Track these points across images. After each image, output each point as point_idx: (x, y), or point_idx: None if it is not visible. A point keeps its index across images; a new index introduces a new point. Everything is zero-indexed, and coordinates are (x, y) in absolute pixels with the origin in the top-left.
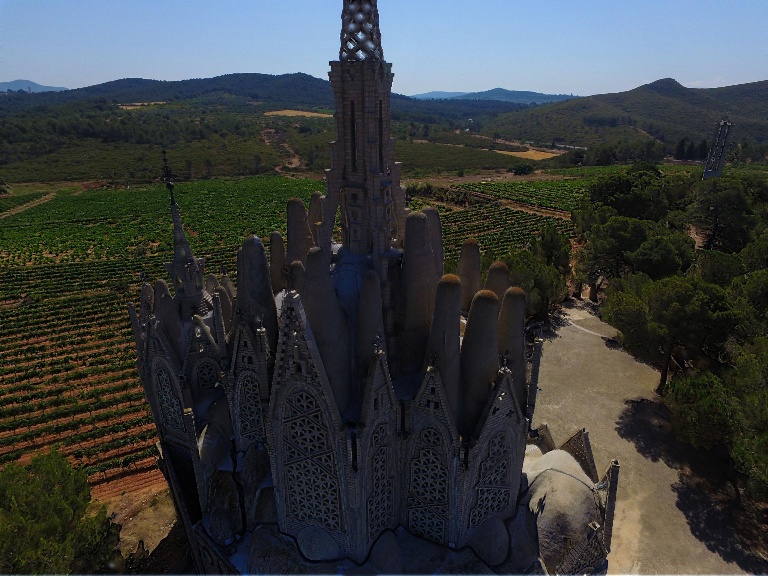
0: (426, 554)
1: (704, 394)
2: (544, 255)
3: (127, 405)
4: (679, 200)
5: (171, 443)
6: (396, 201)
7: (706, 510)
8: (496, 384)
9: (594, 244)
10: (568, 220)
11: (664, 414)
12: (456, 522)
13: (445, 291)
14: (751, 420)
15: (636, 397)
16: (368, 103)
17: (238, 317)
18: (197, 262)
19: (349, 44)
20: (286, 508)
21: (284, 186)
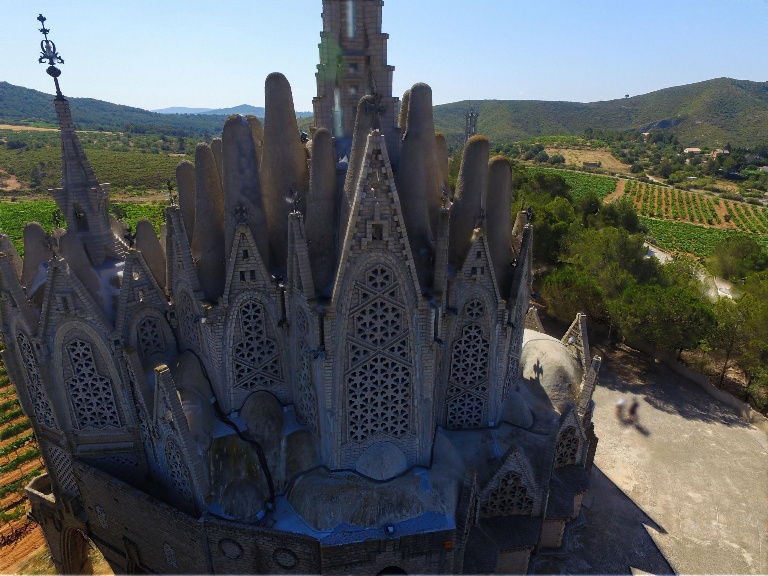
0: (475, 439)
1: None
2: None
3: None
4: None
5: (89, 455)
6: None
7: None
8: (524, 241)
9: None
10: None
11: None
12: (495, 396)
13: (480, 149)
14: (606, 290)
15: None
16: None
17: (205, 237)
18: None
19: None
20: (341, 434)
21: (7, 211)
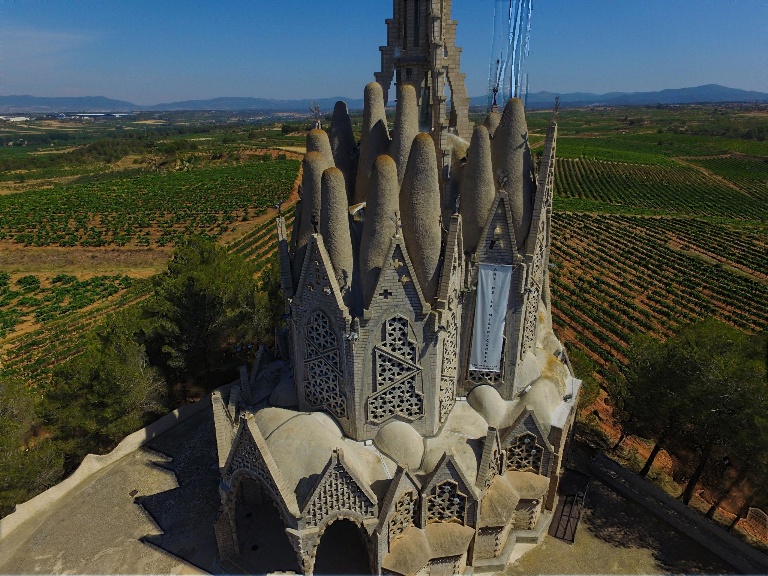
0: None
1: None
2: None
3: None
4: None
5: None
6: None
7: None
8: None
9: None
10: None
11: None
12: None
13: None
14: None
15: None
16: None
17: None
18: None
19: None
20: None
21: None
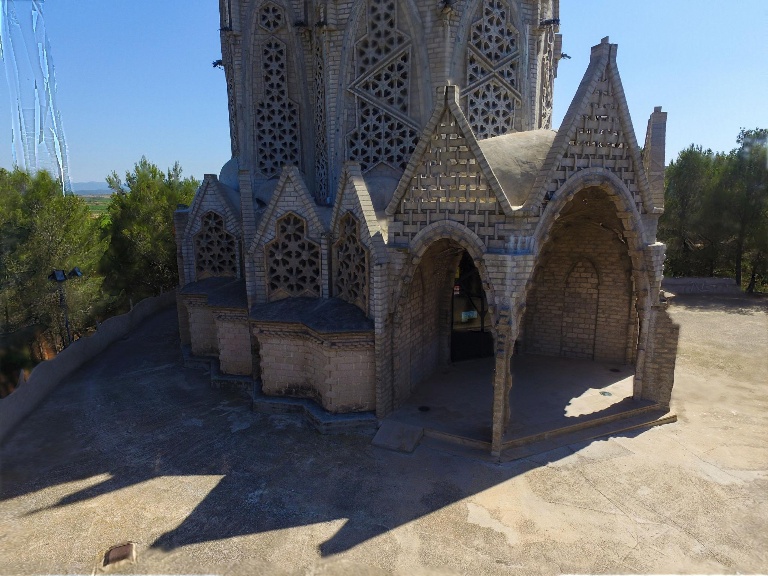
0: None
1: None
2: None
3: None
4: None
5: None
6: None
7: None
8: None
9: None
10: None
11: None
12: (330, 154)
13: None
14: None
15: None
16: None
17: None
18: None
19: None
20: None
21: None
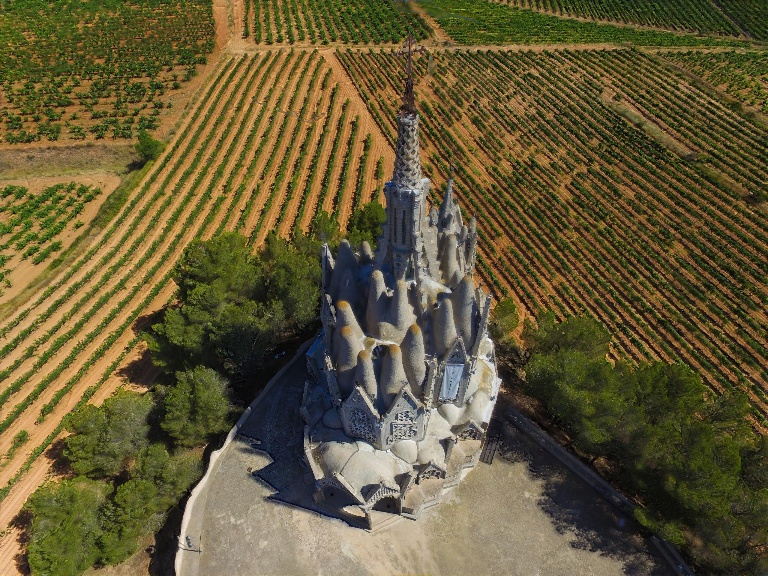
0: None
1: None
2: None
3: None
4: None
5: None
6: None
7: None
8: None
9: None
10: None
11: None
12: None
13: None
14: None
15: None
16: None
17: None
18: (449, 214)
19: None
20: None
21: None
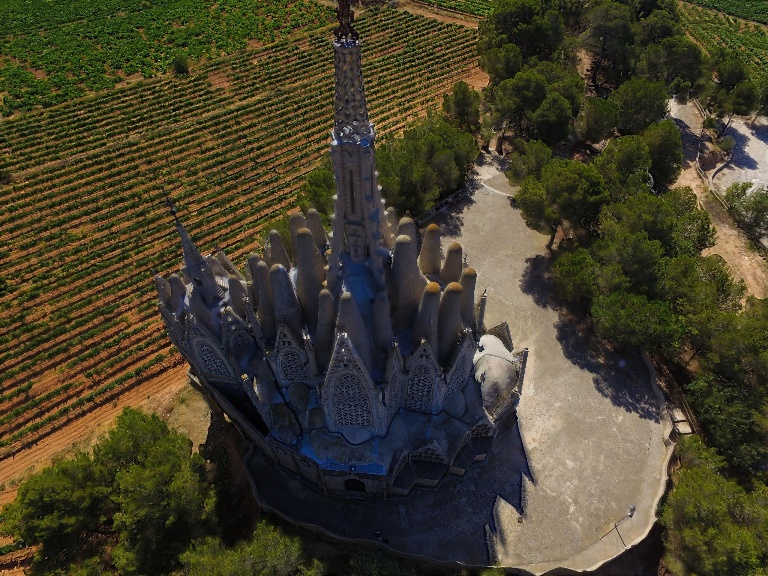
0: (420, 421)
1: (579, 270)
2: (456, 110)
3: (101, 318)
4: (575, 26)
5: (215, 382)
6: (379, 213)
7: (573, 337)
8: (463, 338)
9: (502, 104)
10: (469, 29)
11: (551, 266)
12: (437, 403)
13: (432, 298)
14: (605, 282)
15: (533, 254)
16: (365, 173)
17: (265, 309)
18: (206, 260)
19: (345, 129)
20: (334, 422)
21: None
